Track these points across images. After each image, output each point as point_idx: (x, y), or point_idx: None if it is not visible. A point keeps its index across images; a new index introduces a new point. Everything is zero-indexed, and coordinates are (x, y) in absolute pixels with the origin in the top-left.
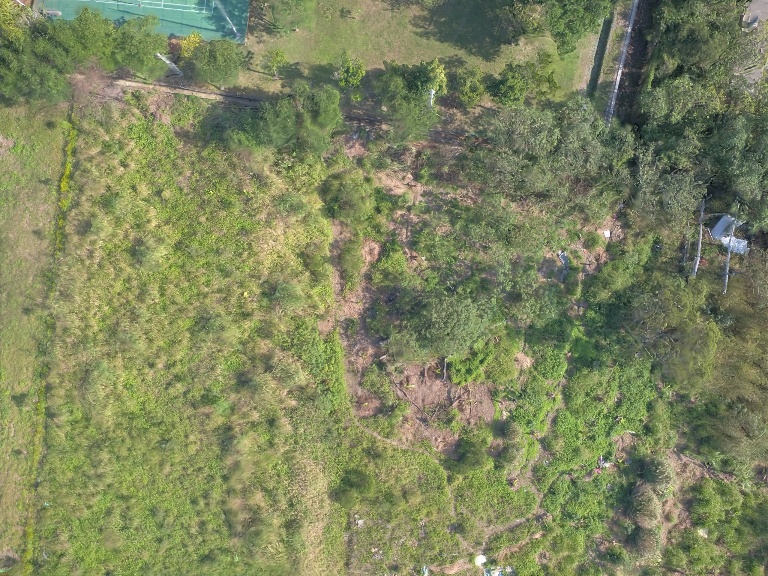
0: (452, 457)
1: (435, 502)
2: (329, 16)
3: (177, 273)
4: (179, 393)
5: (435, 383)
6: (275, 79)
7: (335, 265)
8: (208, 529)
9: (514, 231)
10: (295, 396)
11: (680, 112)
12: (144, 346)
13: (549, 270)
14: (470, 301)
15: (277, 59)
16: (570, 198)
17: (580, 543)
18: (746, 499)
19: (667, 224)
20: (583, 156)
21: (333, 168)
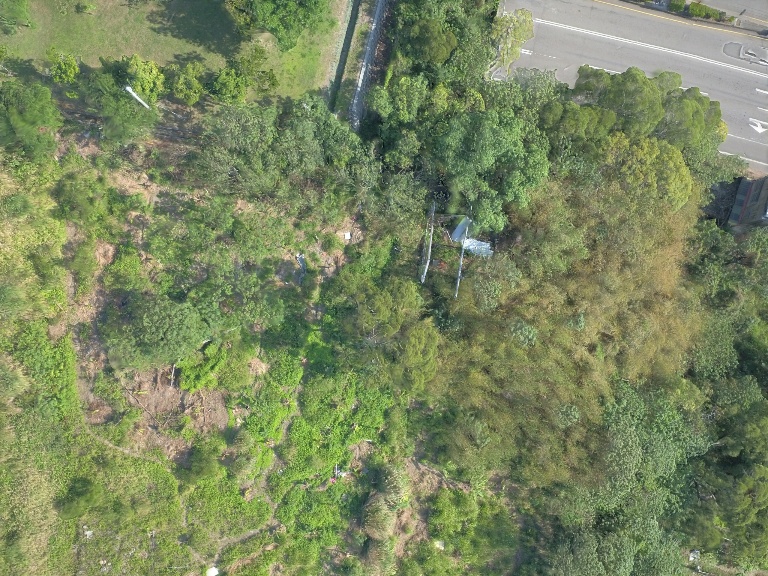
0: (184, 466)
1: (165, 513)
2: (65, 11)
3: None
4: None
5: (168, 389)
6: (9, 76)
7: (69, 268)
8: None
9: None
10: (20, 403)
11: (411, 111)
12: None
13: (287, 273)
14: (189, 305)
15: None
16: None
17: (312, 555)
18: (482, 510)
19: (396, 226)
20: (298, 155)
21: (66, 168)
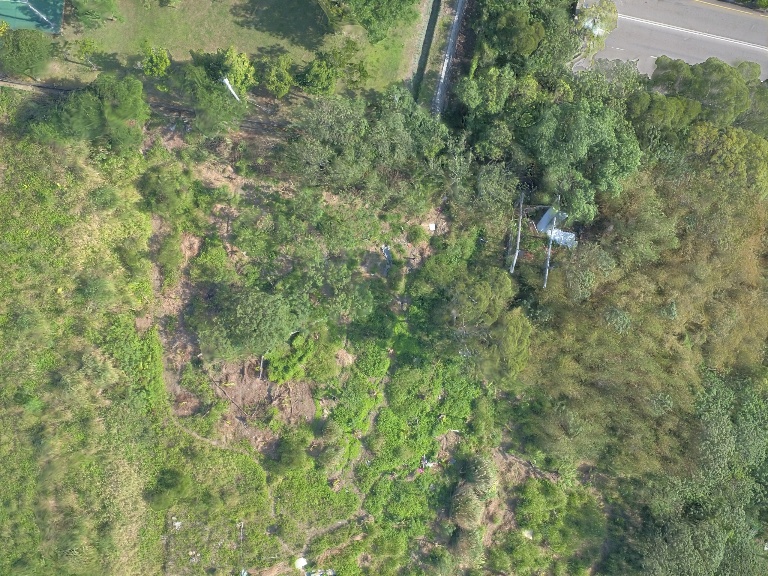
0: (272, 457)
1: (254, 503)
2: (148, 5)
3: None
4: None
5: (255, 381)
6: (93, 70)
7: (154, 260)
8: (20, 532)
9: None
10: (109, 395)
11: (498, 101)
12: None
13: (372, 265)
14: (281, 296)
15: (85, 49)
16: None
17: (401, 545)
18: (570, 499)
19: (485, 217)
20: (391, 147)
21: (152, 161)
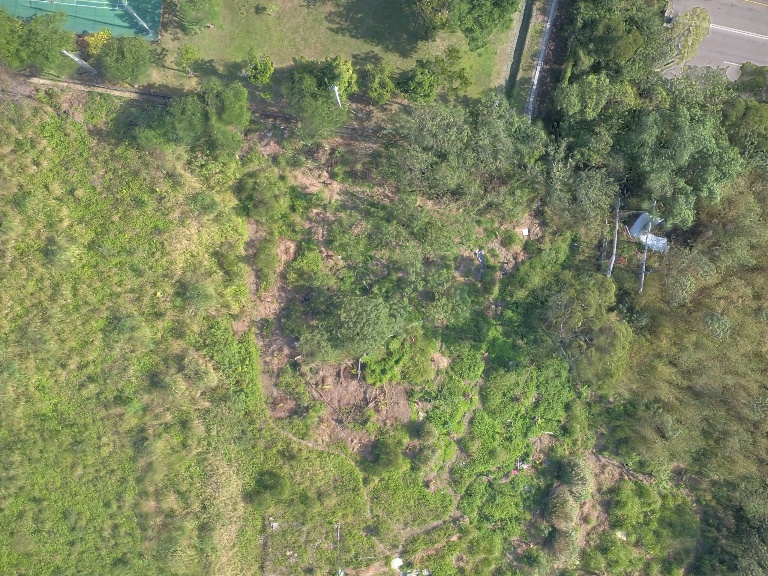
0: (368, 459)
1: (350, 504)
2: (244, 12)
3: (90, 273)
4: (92, 394)
5: (351, 384)
6: (190, 76)
7: (250, 264)
8: (120, 532)
9: (431, 229)
10: (208, 397)
11: (595, 108)
12: (55, 347)
13: (466, 269)
14: (381, 300)
15: (187, 56)
16: (486, 196)
17: (497, 546)
18: (664, 501)
19: (582, 222)
20: (493, 153)
21: (248, 166)
